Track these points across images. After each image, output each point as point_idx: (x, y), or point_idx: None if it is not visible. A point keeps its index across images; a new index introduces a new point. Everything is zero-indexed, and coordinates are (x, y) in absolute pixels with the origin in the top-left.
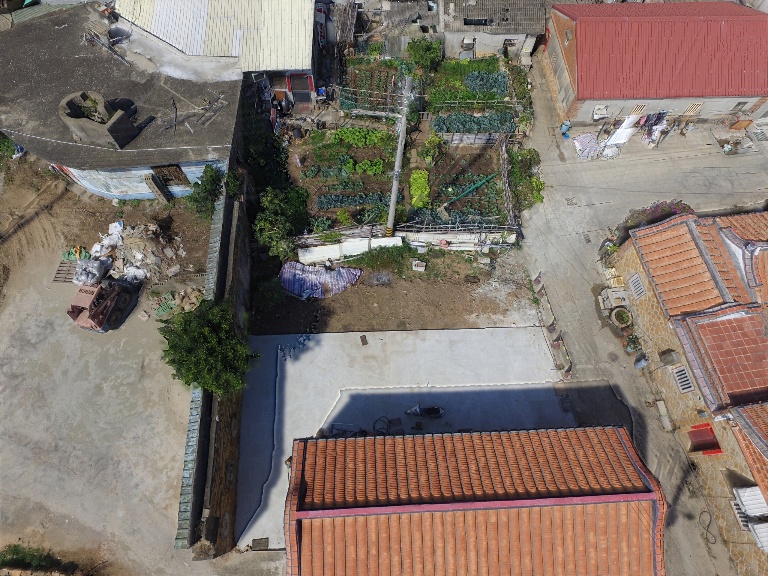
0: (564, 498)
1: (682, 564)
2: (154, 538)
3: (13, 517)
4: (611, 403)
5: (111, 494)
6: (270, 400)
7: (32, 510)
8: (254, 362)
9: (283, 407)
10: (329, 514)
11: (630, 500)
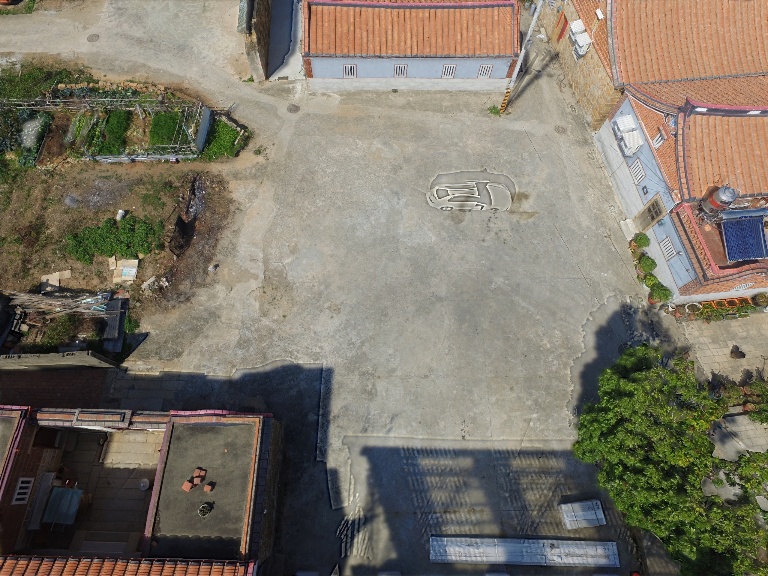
0: (461, 2)
1: (543, 94)
2: (217, 79)
3: (128, 68)
4: None
5: (188, 61)
6: (289, 21)
7: (139, 66)
8: (278, 4)
9: (297, 24)
10: (326, 1)
11: (499, 4)
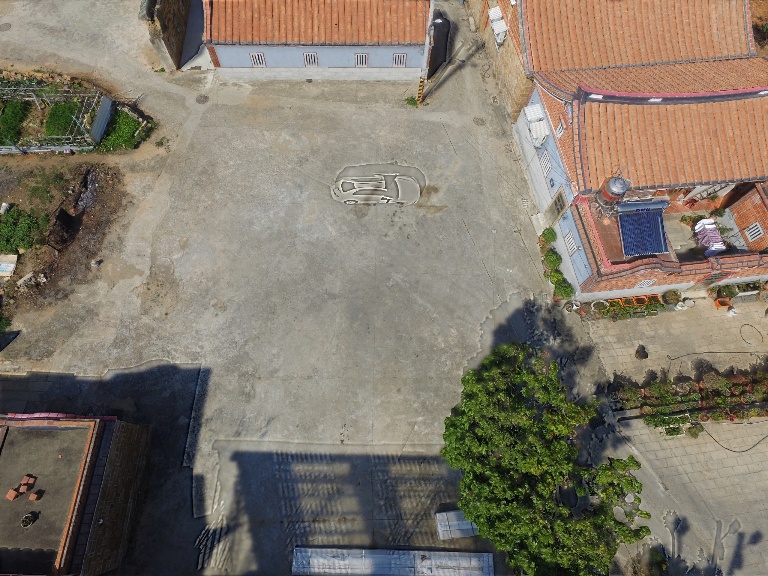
0: None
1: (465, 85)
2: (128, 69)
3: (37, 58)
4: None
5: (101, 50)
6: None
7: (49, 56)
8: None
9: None
10: None
11: None
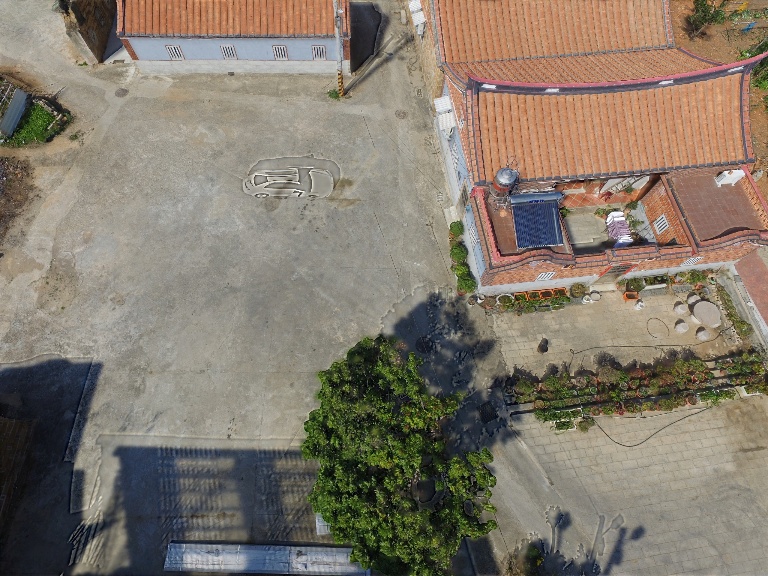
0: None
1: (390, 78)
2: (51, 63)
3: None
4: (370, 12)
5: (26, 44)
6: None
7: None
8: None
9: None
10: None
11: None
